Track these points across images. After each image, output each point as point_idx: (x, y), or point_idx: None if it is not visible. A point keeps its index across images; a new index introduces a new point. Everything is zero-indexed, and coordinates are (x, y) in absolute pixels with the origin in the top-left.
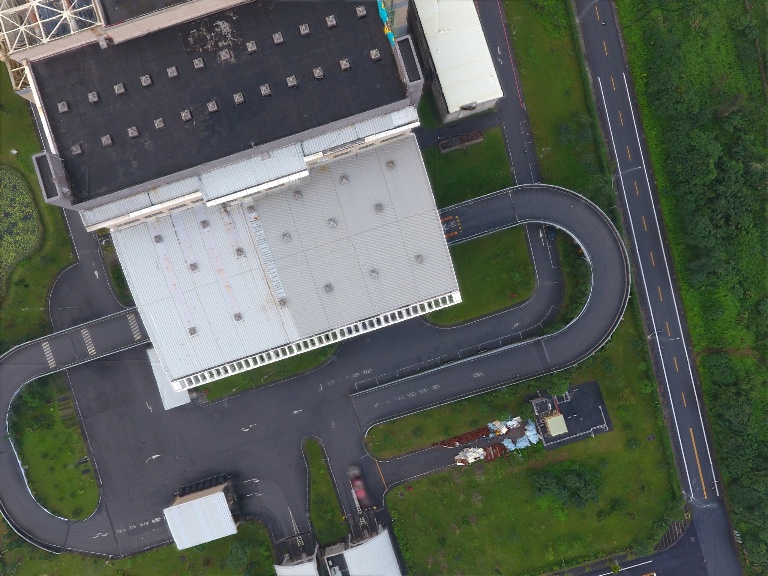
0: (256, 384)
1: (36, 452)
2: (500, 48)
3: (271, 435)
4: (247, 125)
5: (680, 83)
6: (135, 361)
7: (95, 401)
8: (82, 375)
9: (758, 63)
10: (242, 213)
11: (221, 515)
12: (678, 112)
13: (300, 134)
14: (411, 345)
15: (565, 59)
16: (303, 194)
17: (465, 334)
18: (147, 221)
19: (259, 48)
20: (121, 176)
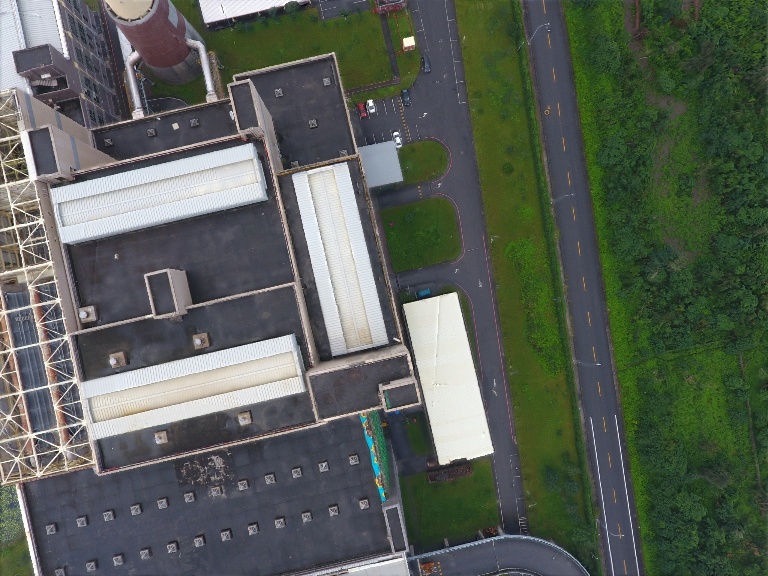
0: None
1: None
2: (496, 380)
3: None
4: (232, 561)
5: (670, 436)
6: None
7: None
8: None
9: (748, 421)
10: None
11: None
12: (665, 469)
13: None
14: None
15: (559, 398)
16: None
17: None
18: None
19: (250, 486)
20: None
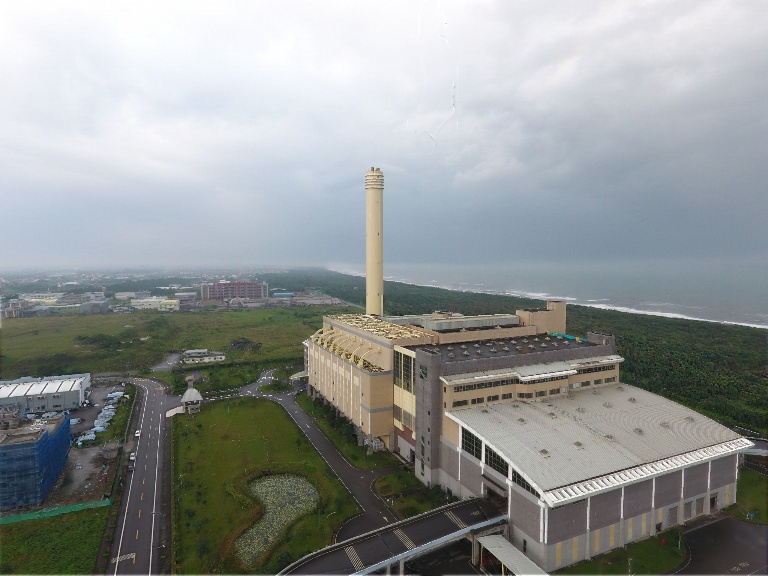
0: None
1: None
2: None
3: None
4: (530, 352)
5: None
6: None
7: None
8: None
9: None
10: None
11: None
12: None
13: (564, 351)
14: (762, 540)
15: None
16: None
17: None
18: None
19: None
20: None
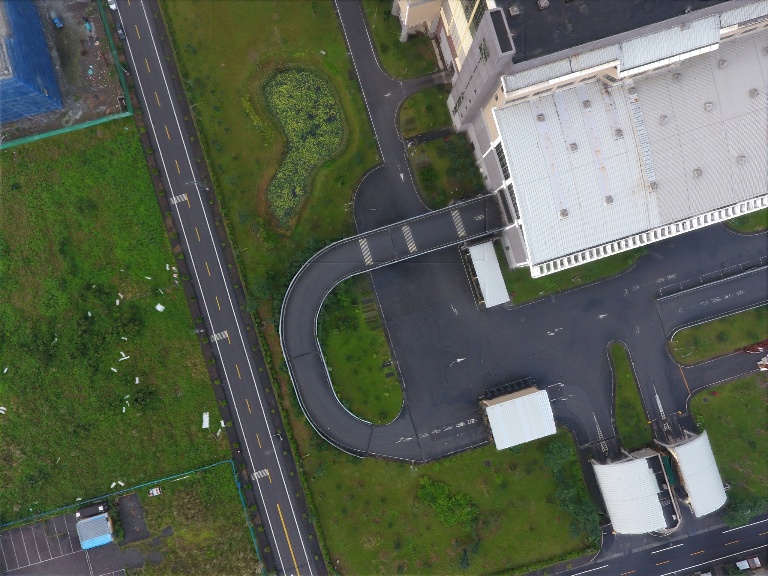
0: (562, 288)
1: (340, 354)
2: None
3: (576, 339)
4: None
5: None
6: (440, 264)
7: (399, 304)
8: (386, 277)
9: None
10: (623, 94)
11: (543, 414)
12: None
13: (735, 1)
14: (714, 251)
15: None
16: (682, 77)
17: (767, 241)
18: (530, 100)
19: None
20: (556, 38)
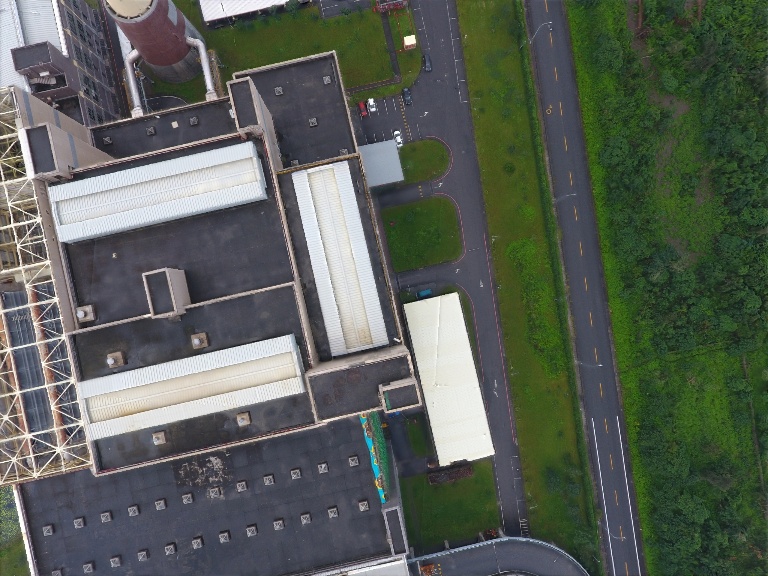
0: None
1: None
2: (497, 381)
3: None
4: (230, 563)
5: (672, 438)
6: None
7: None
8: None
9: (751, 423)
10: None
11: None
12: (668, 471)
13: None
14: None
15: (560, 399)
16: None
17: None
18: None
19: (249, 487)
20: None
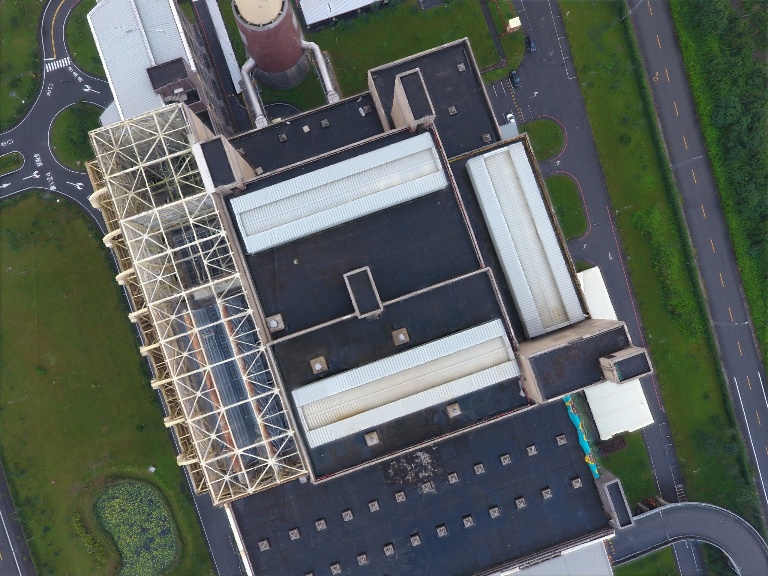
0: None
1: None
2: None
3: None
4: (450, 557)
5: None
6: None
7: None
8: None
9: None
10: None
11: None
12: None
13: None
14: None
15: (702, 362)
16: None
17: None
18: None
19: (460, 478)
20: None
